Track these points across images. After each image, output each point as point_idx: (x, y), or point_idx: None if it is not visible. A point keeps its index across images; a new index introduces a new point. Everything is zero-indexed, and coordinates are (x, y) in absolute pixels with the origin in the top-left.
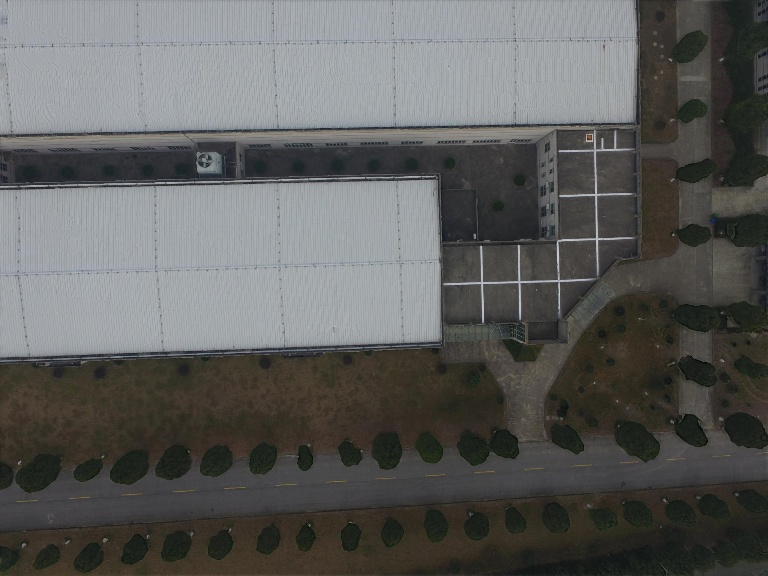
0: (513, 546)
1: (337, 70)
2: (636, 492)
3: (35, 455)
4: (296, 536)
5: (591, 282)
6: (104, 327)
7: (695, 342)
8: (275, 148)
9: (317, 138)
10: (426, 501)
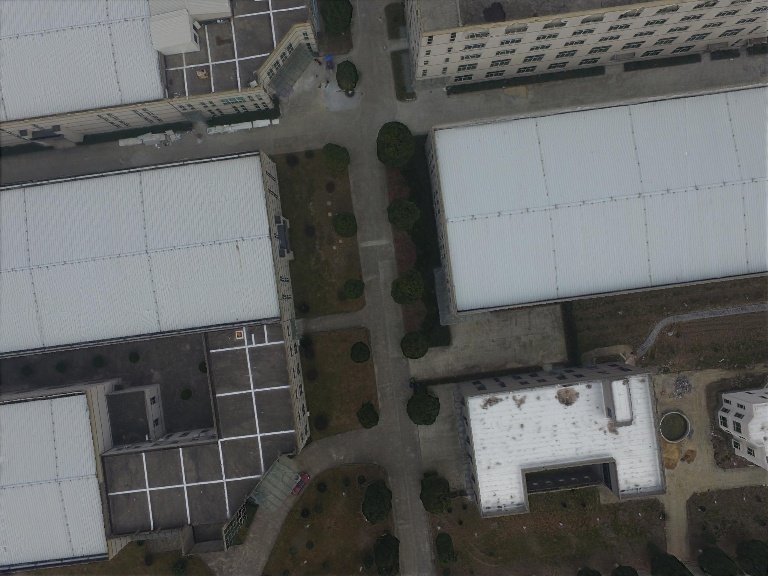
0: None
1: None
2: None
3: None
4: None
5: (257, 479)
6: None
7: (409, 510)
8: None
9: None
10: None
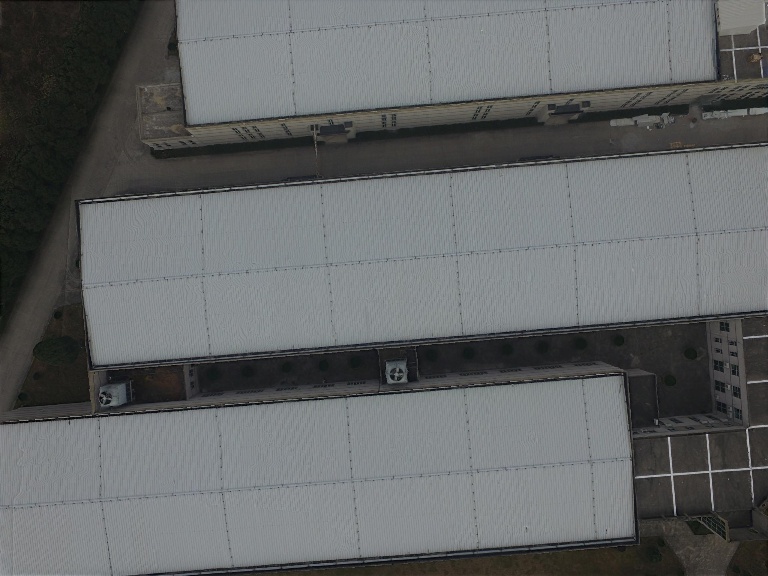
0: None
1: (525, 282)
2: None
3: None
4: None
5: None
6: (303, 537)
7: None
8: None
9: None
10: None
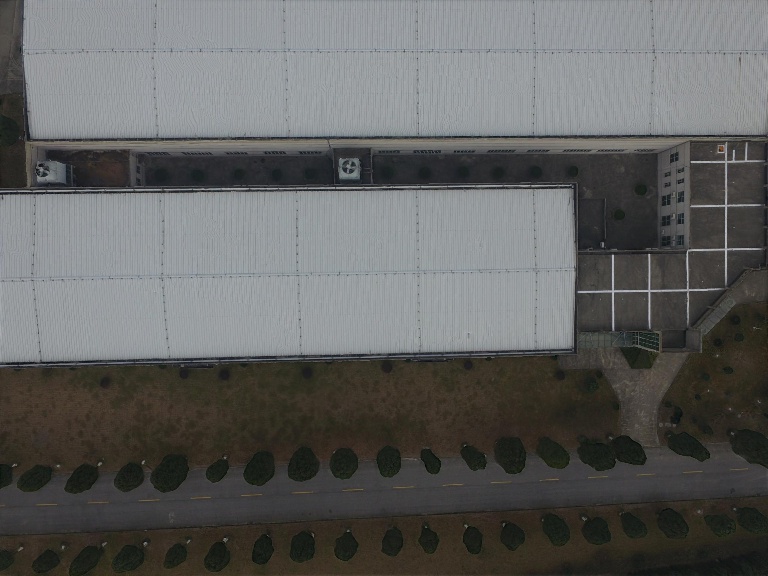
0: (624, 550)
1: (483, 79)
2: (745, 499)
3: (158, 455)
4: (419, 538)
5: (719, 292)
6: (244, 330)
7: None
8: (402, 154)
9: (452, 145)
10: (540, 505)
